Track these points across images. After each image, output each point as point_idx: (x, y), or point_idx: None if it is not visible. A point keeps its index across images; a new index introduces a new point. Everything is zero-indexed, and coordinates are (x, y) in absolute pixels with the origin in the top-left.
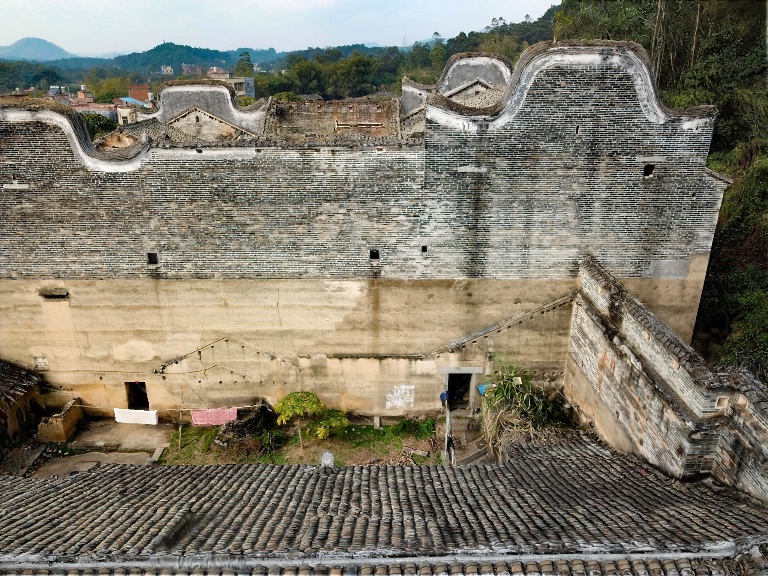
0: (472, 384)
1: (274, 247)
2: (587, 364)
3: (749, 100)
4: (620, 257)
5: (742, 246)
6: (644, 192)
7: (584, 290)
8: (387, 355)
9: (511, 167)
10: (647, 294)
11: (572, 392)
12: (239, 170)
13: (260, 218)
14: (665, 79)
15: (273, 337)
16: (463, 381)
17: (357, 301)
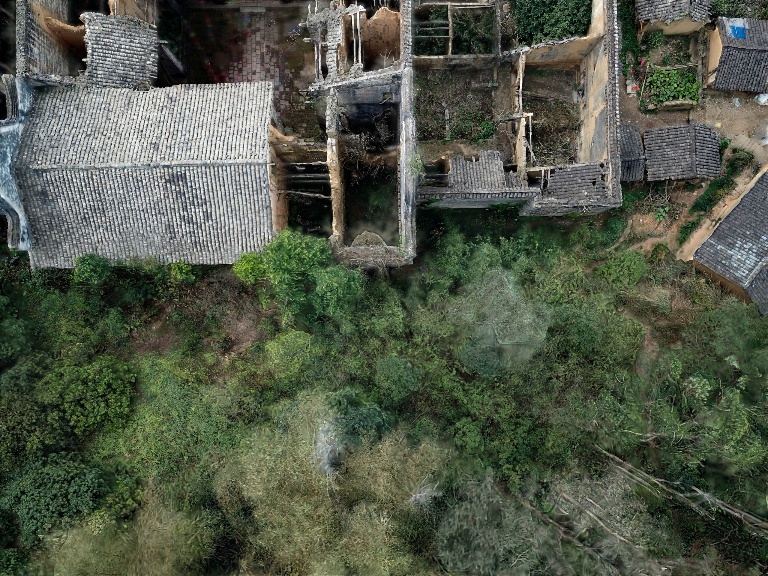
0: None
1: None
2: None
3: None
4: None
5: None
6: None
7: None
8: None
9: None
10: None
11: None
12: None
13: None
14: (640, 492)
15: None
16: None
17: None
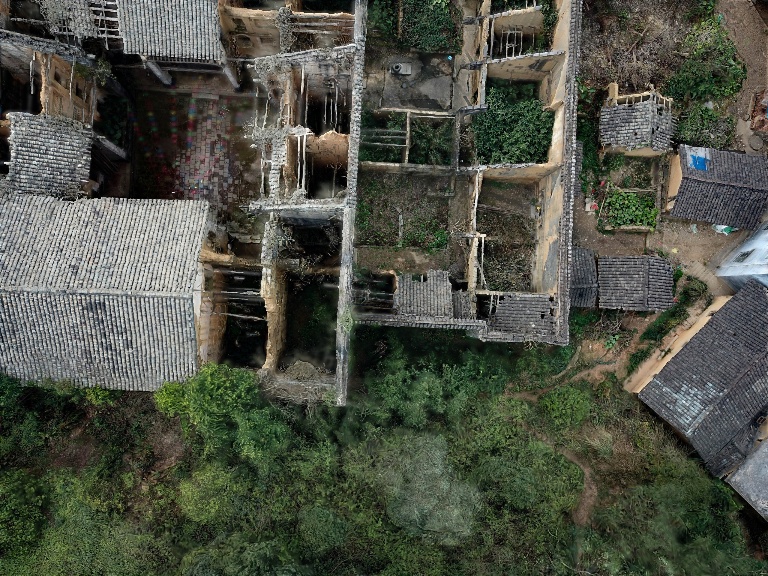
0: None
1: None
2: None
3: None
4: None
5: None
6: None
7: None
8: None
9: None
10: None
11: None
12: None
13: None
14: None
15: None
16: None
17: None
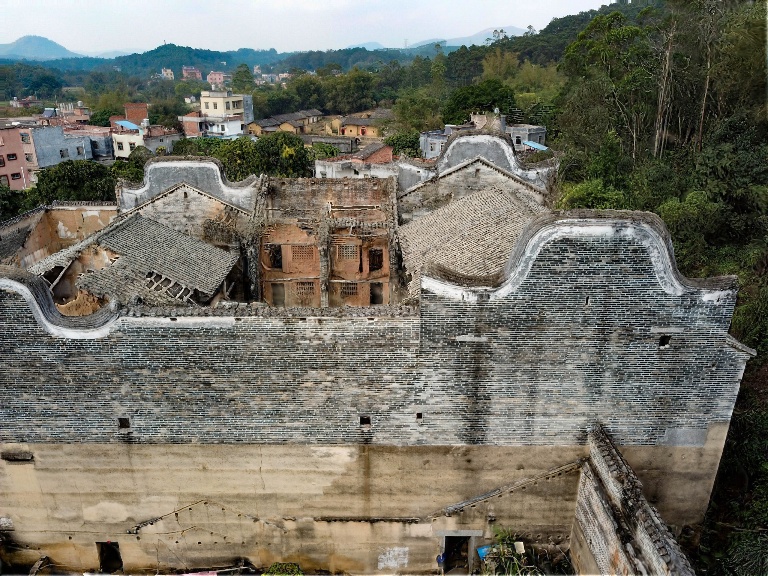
0: (471, 546)
1: (256, 413)
2: (596, 546)
3: (765, 197)
4: (632, 425)
5: (759, 372)
6: (659, 362)
7: (593, 460)
8: (379, 518)
9: (514, 337)
10: (661, 461)
11: (579, 563)
12: (217, 338)
13: (240, 385)
14: (672, 139)
15: (256, 500)
16: (461, 538)
17: (346, 466)
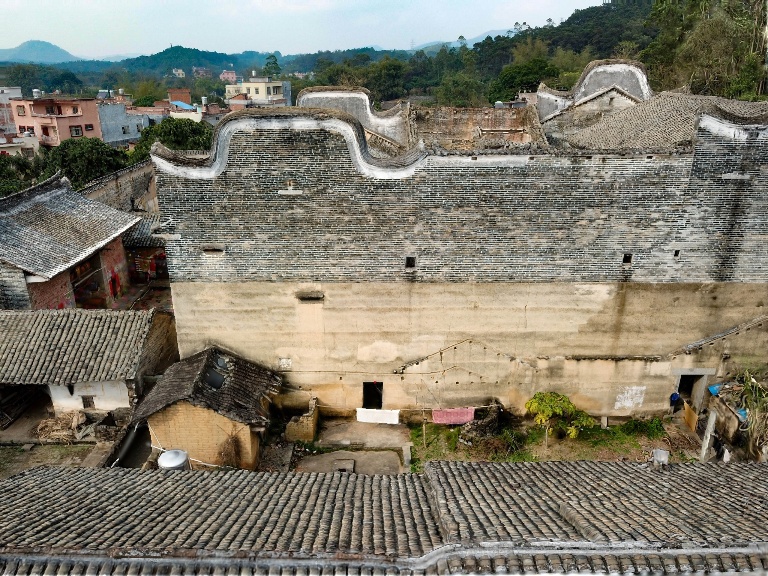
0: (702, 385)
1: (531, 251)
2: None
3: None
4: None
5: None
6: None
7: None
8: (624, 356)
9: None
10: None
11: None
12: (510, 177)
13: (522, 223)
14: None
15: (516, 339)
16: (687, 382)
17: (604, 304)
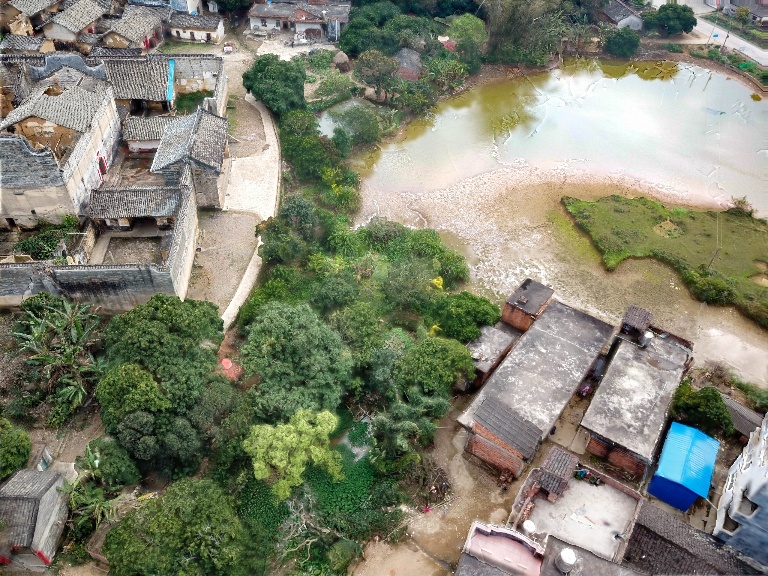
0: None
1: None
2: None
3: None
4: None
5: None
6: None
7: None
8: None
9: None
10: None
11: None
12: None
13: None
14: None
15: None
16: None
17: None
